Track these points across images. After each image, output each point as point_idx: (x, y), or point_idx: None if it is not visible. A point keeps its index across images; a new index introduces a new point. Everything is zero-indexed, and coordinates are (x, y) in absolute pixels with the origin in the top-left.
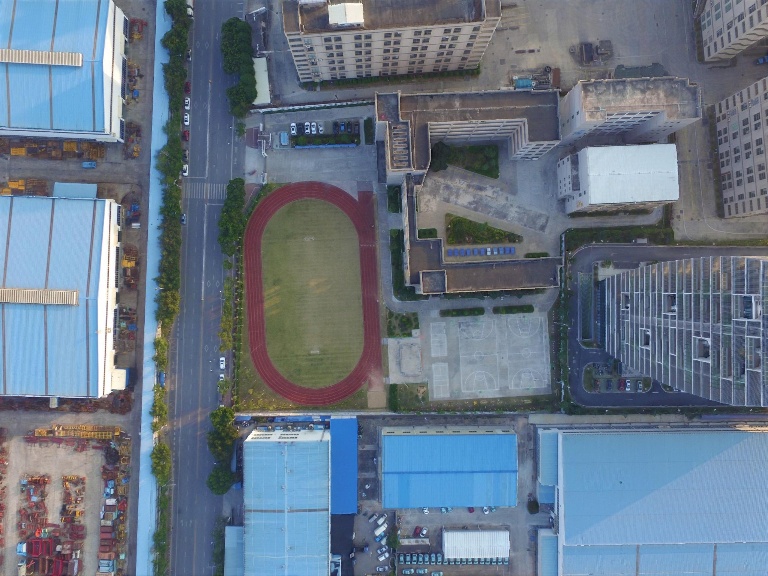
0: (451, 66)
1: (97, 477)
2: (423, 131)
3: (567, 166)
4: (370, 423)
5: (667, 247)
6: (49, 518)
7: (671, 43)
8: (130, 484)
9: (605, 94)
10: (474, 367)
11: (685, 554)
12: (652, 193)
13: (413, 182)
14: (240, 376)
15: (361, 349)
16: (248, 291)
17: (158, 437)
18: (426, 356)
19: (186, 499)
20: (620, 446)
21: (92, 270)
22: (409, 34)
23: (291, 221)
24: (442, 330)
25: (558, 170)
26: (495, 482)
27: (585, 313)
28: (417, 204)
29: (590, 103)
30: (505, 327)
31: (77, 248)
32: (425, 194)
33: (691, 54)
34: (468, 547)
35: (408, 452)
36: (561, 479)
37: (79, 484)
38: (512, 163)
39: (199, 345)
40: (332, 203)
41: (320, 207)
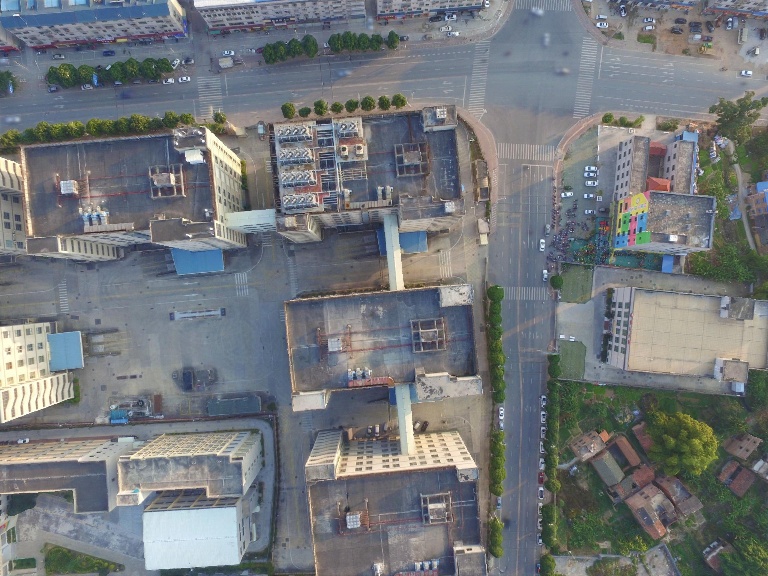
0: None
1: None
2: None
3: None
4: None
5: None
6: None
7: (278, 366)
8: None
9: (147, 470)
10: None
11: None
12: (210, 559)
13: None
14: None
15: None
16: None
17: None
18: None
19: None
20: None
21: None
22: None
23: None
24: None
25: None
26: None
27: None
28: (15, 534)
29: (131, 480)
30: None
31: None
32: (24, 523)
33: None
34: None
35: None
36: None
37: None
38: None
39: None
40: None
41: None
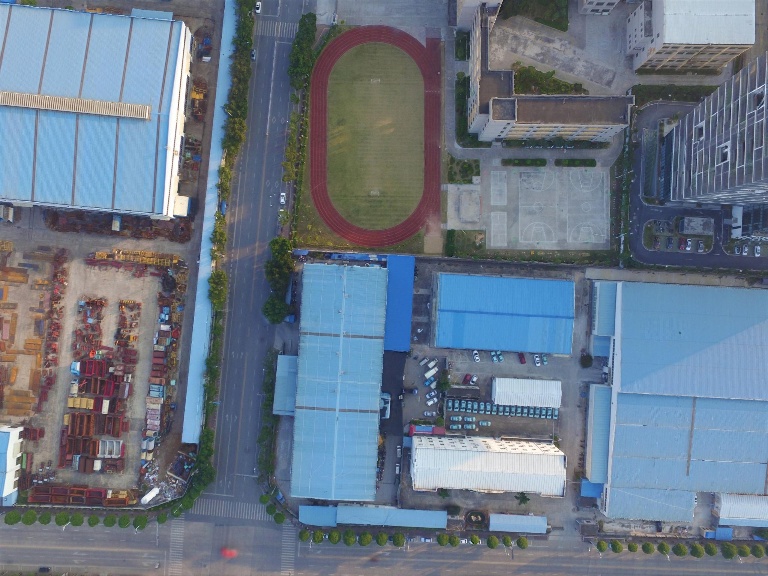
0: None
1: (153, 303)
2: None
3: (640, 14)
4: (426, 267)
5: None
6: (103, 341)
7: None
8: (185, 313)
9: None
10: (533, 218)
11: (743, 412)
12: (728, 36)
13: (487, 14)
14: (299, 212)
15: (420, 194)
16: (312, 129)
17: (215, 267)
18: (485, 204)
19: (239, 331)
20: (681, 297)
21: (165, 87)
22: None
23: (358, 63)
24: (503, 179)
25: (628, 26)
26: (551, 328)
27: (648, 172)
28: None
29: None
30: (566, 180)
31: (152, 65)
32: (493, 43)
33: None
34: (519, 393)
35: (465, 291)
36: (619, 326)
37: (135, 309)
38: (581, 17)
39: (261, 180)
40: (400, 48)
41: (388, 51)
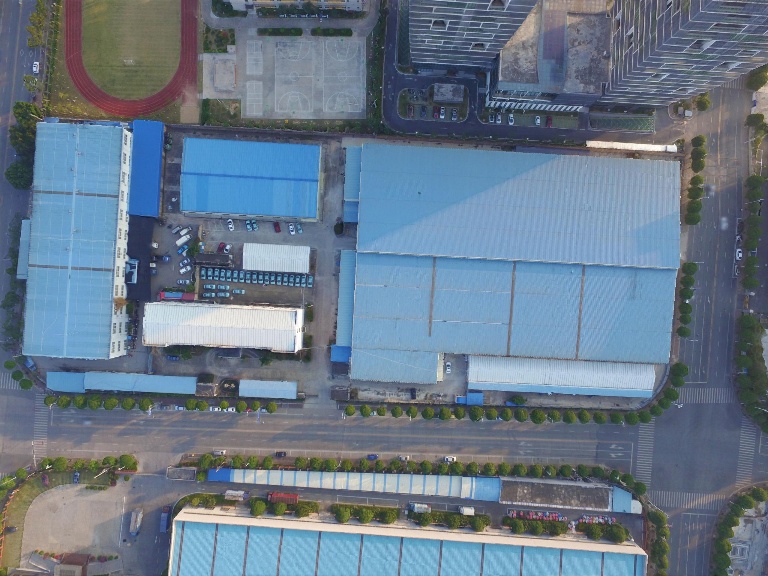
0: None
1: None
2: None
3: None
4: (180, 136)
5: None
6: None
7: None
8: None
9: None
10: (289, 87)
11: (483, 272)
12: None
13: None
14: (53, 82)
15: (177, 64)
16: None
17: None
18: (241, 73)
19: None
20: (422, 158)
21: None
22: None
23: None
24: (258, 48)
25: None
26: (295, 191)
27: (405, 42)
28: None
29: None
30: (322, 49)
31: None
32: None
33: None
34: (266, 258)
35: (209, 155)
36: None
37: None
38: None
39: (15, 49)
40: None
41: None
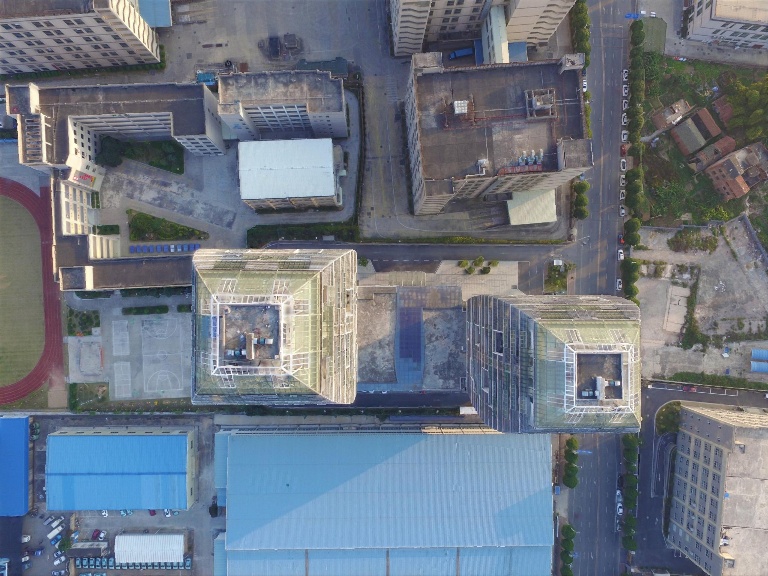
0: (128, 60)
1: None
2: (65, 125)
3: None
4: (49, 423)
5: (357, 244)
6: None
7: (363, 37)
8: None
9: (246, 87)
10: (157, 366)
11: (356, 559)
12: (306, 189)
13: (61, 177)
14: None
15: (42, 347)
16: None
17: None
18: (107, 355)
19: None
20: (289, 448)
21: None
22: (30, 25)
23: None
24: (124, 328)
25: None
26: (164, 484)
27: None
28: (99, 200)
29: (230, 96)
30: None
31: None
32: (108, 190)
33: (384, 49)
34: (139, 551)
35: (73, 453)
36: (227, 481)
37: None
38: (198, 159)
39: None
40: (13, 199)
41: (1, 203)
